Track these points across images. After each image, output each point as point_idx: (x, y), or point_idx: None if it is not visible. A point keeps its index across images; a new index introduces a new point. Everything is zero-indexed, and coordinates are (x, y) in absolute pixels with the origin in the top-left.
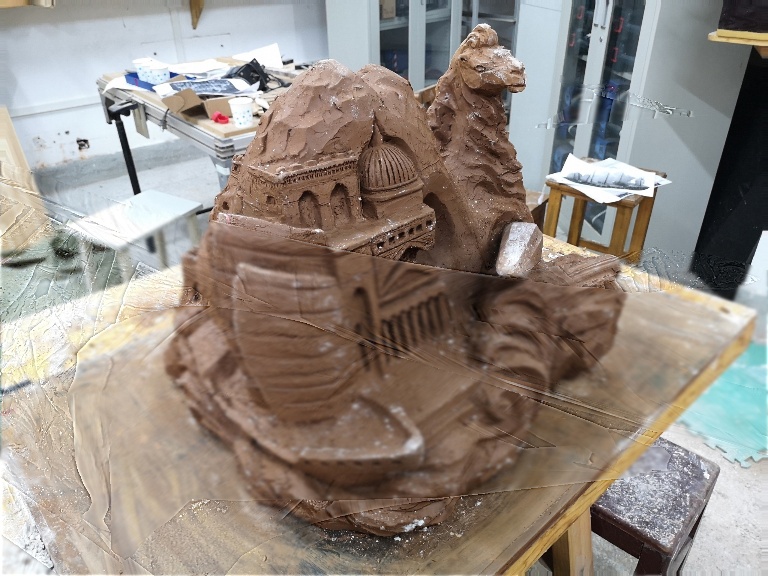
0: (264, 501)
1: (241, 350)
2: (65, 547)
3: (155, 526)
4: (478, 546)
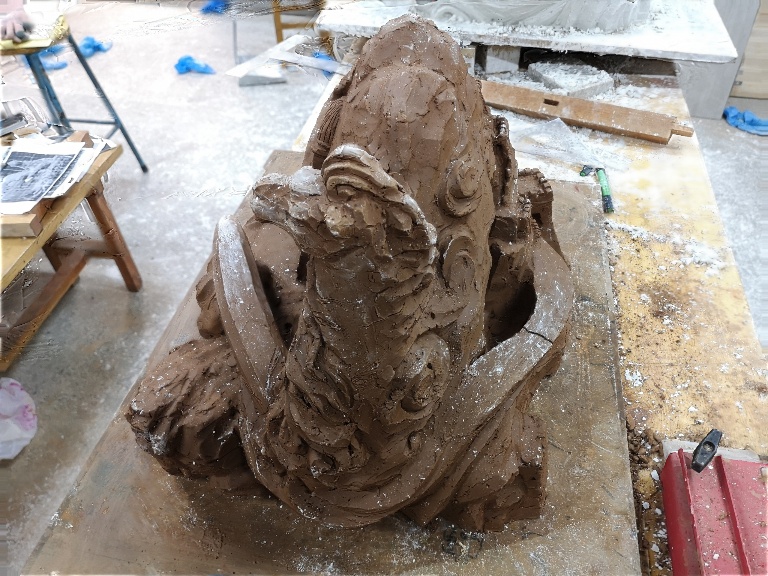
0: (231, 22)
1: None
2: None
3: None
4: None
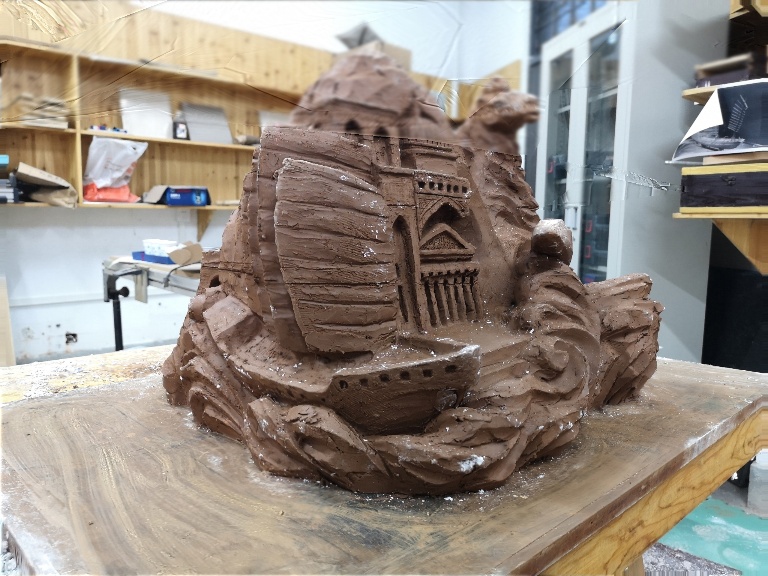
0: None
1: None
2: (20, 505)
3: None
4: (551, 504)
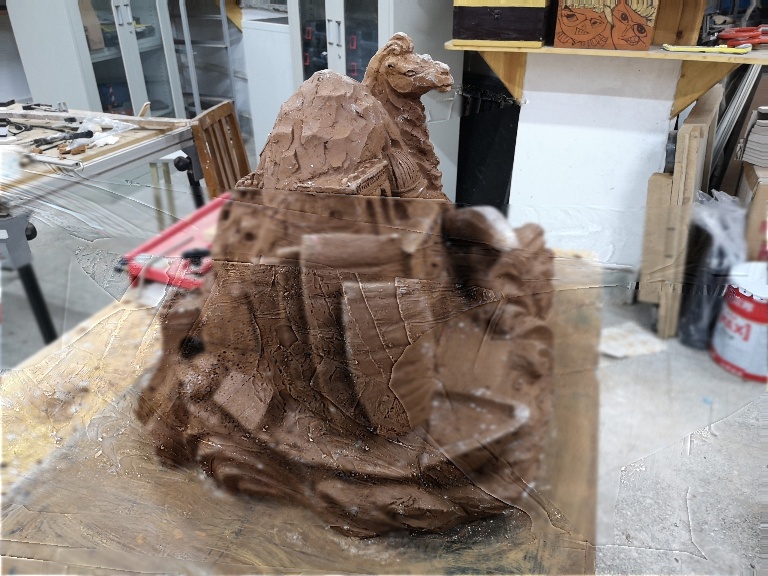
0: (665, 447)
1: (564, 328)
2: None
3: (612, 504)
4: None
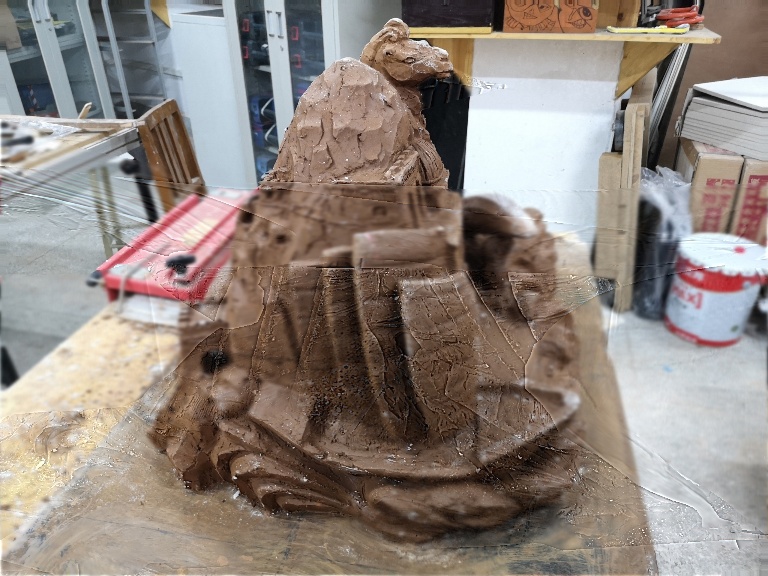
0: None
1: (683, 312)
2: None
3: None
4: None
